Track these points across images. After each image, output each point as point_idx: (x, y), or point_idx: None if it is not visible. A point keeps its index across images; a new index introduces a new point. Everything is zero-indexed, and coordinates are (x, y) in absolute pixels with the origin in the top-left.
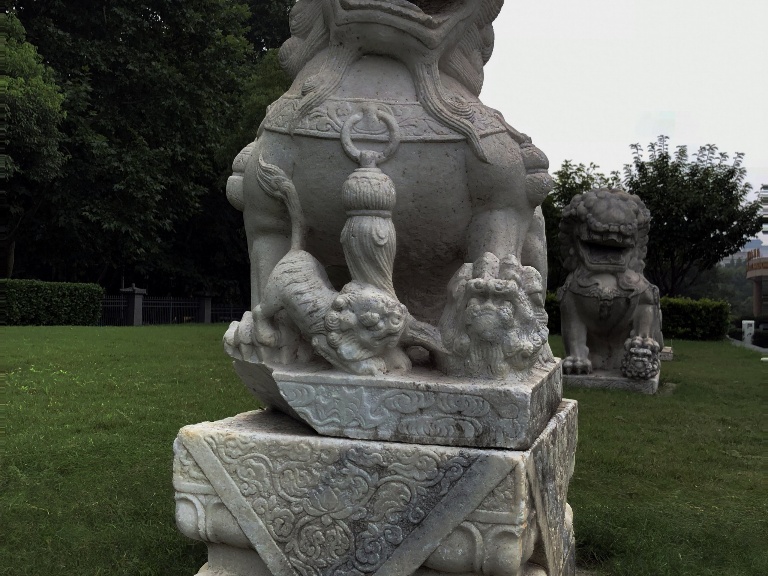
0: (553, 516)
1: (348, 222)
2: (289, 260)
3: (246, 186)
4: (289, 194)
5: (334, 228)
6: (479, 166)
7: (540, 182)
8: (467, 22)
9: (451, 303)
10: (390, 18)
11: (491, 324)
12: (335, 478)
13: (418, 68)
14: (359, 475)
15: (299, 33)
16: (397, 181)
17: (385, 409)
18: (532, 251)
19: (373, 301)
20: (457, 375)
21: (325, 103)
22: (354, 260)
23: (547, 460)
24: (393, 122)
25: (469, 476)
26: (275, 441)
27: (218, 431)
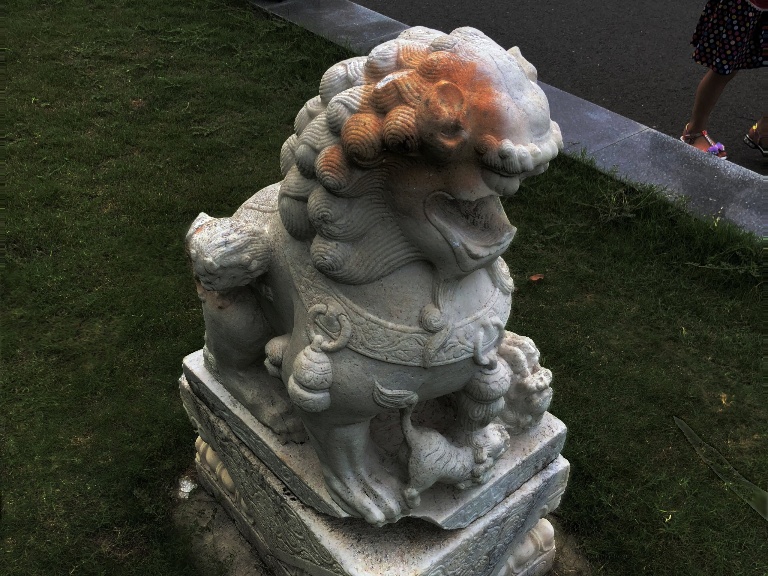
0: None
1: (484, 408)
2: (434, 450)
3: (347, 404)
4: None
5: None
6: None
7: None
8: None
9: None
10: None
11: None
12: (480, 542)
13: None
14: None
15: None
16: None
17: None
18: None
19: (502, 443)
20: (514, 434)
21: (454, 333)
22: None
23: None
24: (502, 323)
25: None
26: None
27: None
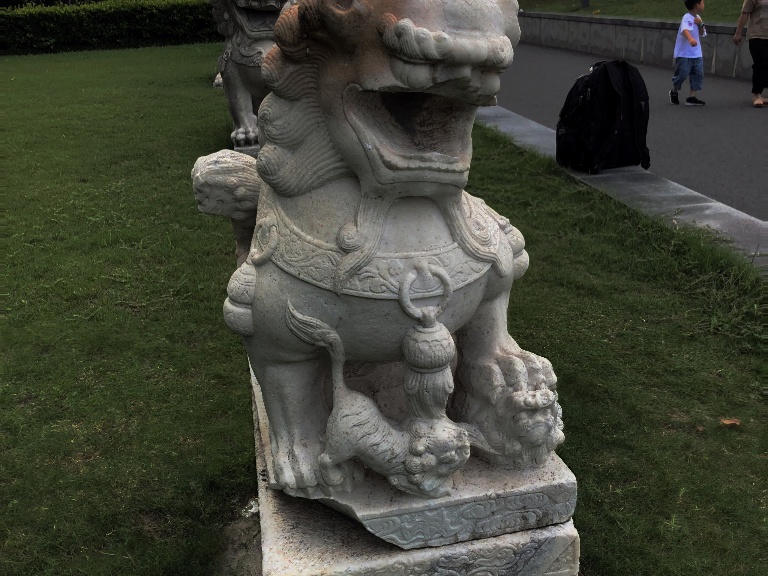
0: None
1: (418, 378)
2: (353, 412)
3: (264, 325)
4: (335, 344)
5: (374, 360)
6: (499, 281)
7: (525, 265)
8: None
9: (481, 401)
10: (437, 176)
11: (542, 434)
12: None
13: (450, 207)
14: (449, 575)
15: (283, 144)
16: (447, 323)
17: (463, 519)
18: None
19: (450, 442)
20: (505, 468)
21: (373, 262)
22: (423, 407)
23: None
24: (447, 277)
25: (540, 554)
26: (370, 569)
27: (311, 573)
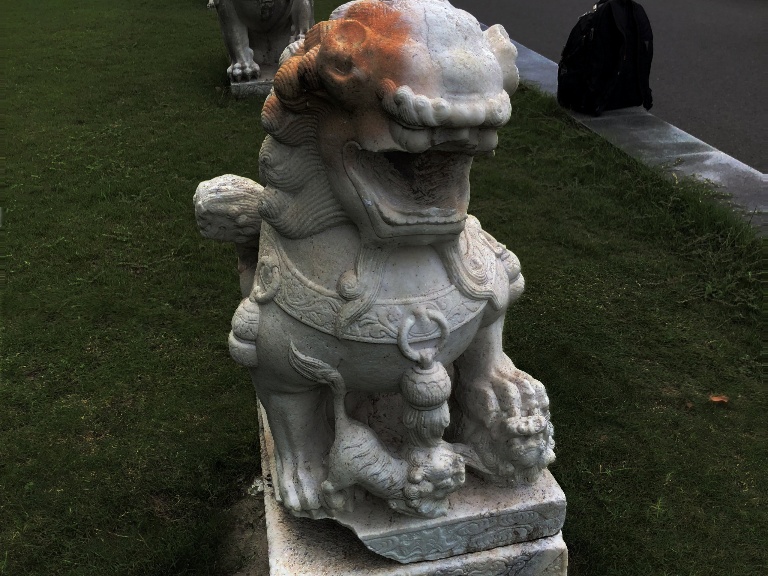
0: None
1: (416, 415)
2: (354, 445)
3: (268, 362)
4: (336, 382)
5: None
6: (494, 314)
7: (521, 290)
8: None
9: (476, 423)
10: (435, 229)
11: (534, 458)
12: None
13: (448, 252)
14: None
15: (284, 188)
16: (444, 360)
17: (458, 536)
18: None
19: (446, 471)
20: (498, 485)
21: (373, 309)
22: (421, 439)
23: None
24: (444, 321)
25: (530, 565)
26: None
27: None
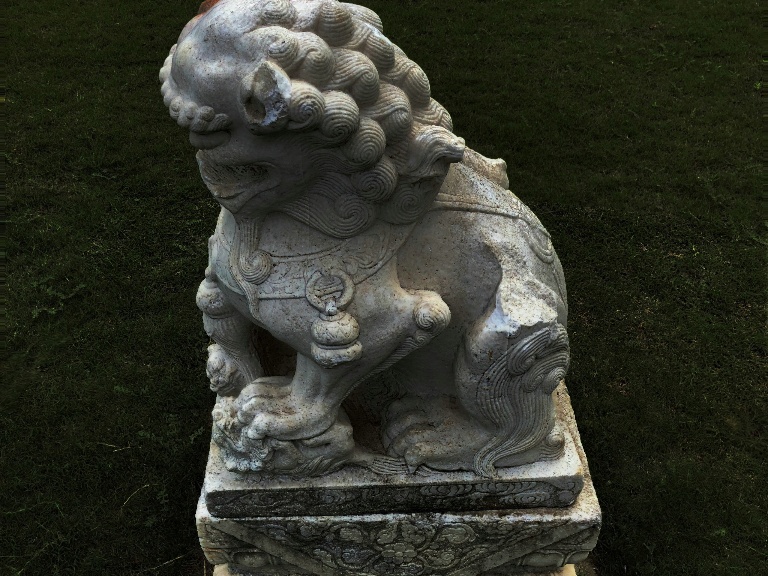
0: (368, 568)
1: None
2: None
3: None
4: None
5: None
6: None
7: (313, 356)
8: (280, 189)
9: None
10: None
11: None
12: None
13: None
14: None
15: None
16: (226, 297)
17: None
18: (456, 379)
19: (208, 364)
20: None
21: None
22: None
23: (322, 534)
24: (212, 259)
25: None
26: None
27: None
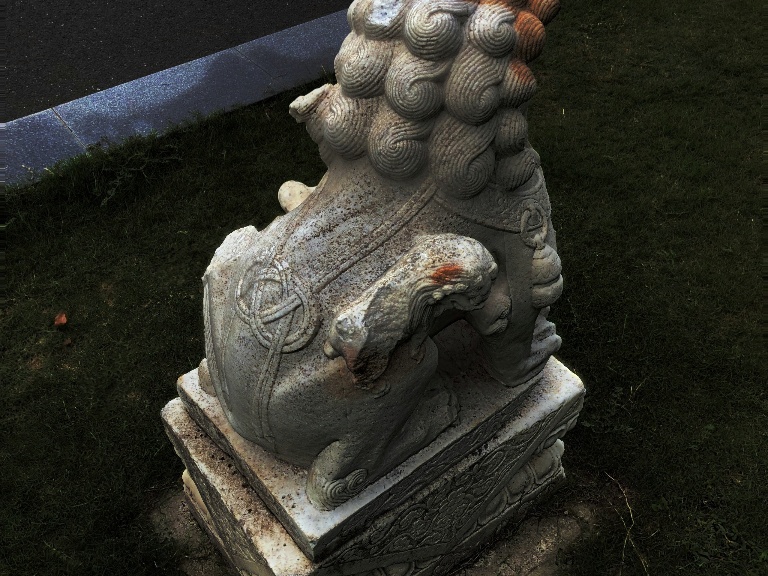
0: None
1: None
2: None
3: None
4: None
5: None
6: None
7: None
8: None
9: None
10: None
11: None
12: None
13: None
14: None
15: None
16: None
17: None
18: None
19: None
20: None
21: None
22: None
23: None
24: None
25: None
26: None
27: None
